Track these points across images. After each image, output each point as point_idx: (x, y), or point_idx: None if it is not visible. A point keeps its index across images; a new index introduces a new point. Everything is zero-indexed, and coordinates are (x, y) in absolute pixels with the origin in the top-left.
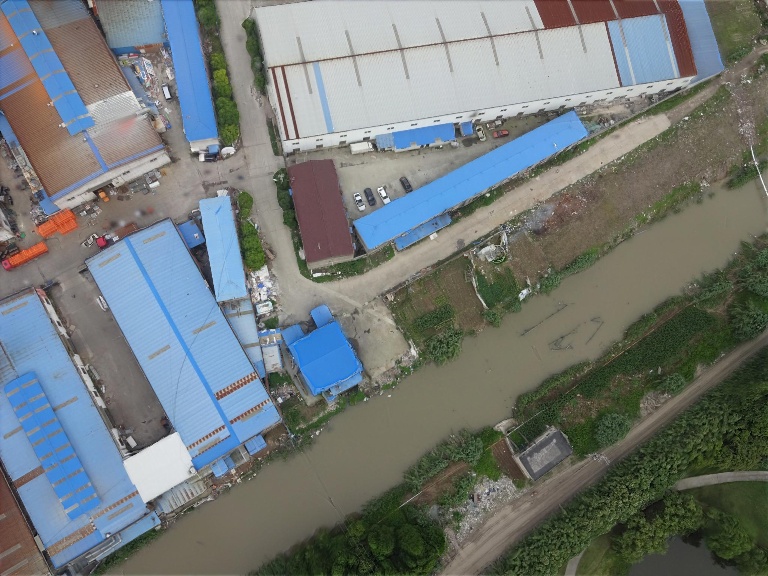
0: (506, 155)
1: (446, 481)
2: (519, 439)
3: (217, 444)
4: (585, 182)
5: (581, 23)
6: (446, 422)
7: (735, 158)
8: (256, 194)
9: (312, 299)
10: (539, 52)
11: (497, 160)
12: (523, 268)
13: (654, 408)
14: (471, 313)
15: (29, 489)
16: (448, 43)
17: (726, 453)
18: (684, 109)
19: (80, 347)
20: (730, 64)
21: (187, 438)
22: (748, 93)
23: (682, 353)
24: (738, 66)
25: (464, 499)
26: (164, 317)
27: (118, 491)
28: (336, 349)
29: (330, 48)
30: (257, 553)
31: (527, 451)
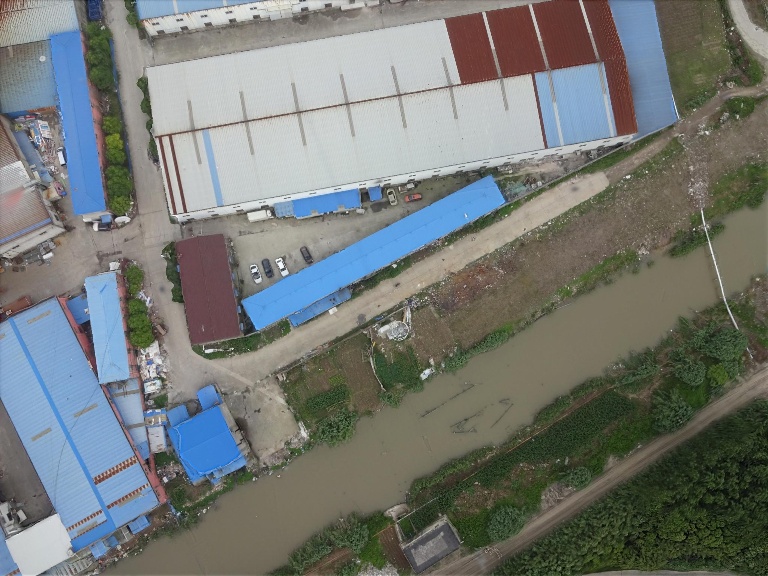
0: (410, 228)
1: (329, 567)
2: (408, 527)
3: (94, 528)
4: (504, 251)
5: (504, 76)
6: (335, 505)
7: (681, 223)
8: (150, 265)
9: (203, 376)
10: (453, 111)
11: (400, 233)
12: (426, 347)
13: (556, 501)
14: (368, 393)
15: None
16: (350, 104)
17: (628, 554)
18: (626, 166)
19: None
20: (687, 112)
21: (67, 520)
22: (704, 147)
23: (593, 443)
24: (696, 114)
25: None
26: (46, 400)
27: None
28: (216, 436)
29: (222, 113)
30: None
31: (412, 543)
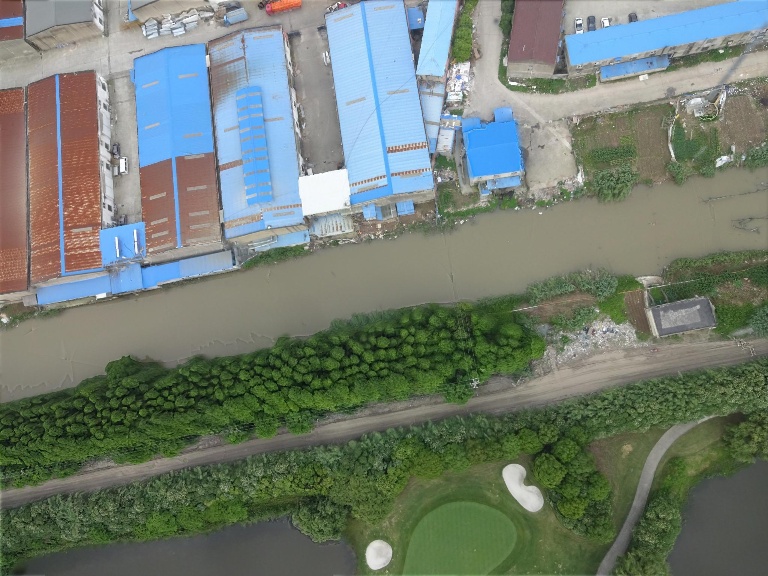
0: (758, 6)
1: (566, 305)
2: (659, 296)
3: (374, 189)
4: None
5: None
6: (588, 256)
7: None
8: None
9: (500, 103)
10: None
11: (745, 9)
12: (732, 133)
13: None
14: (655, 162)
15: (228, 174)
16: None
17: None
18: None
19: (298, 87)
20: None
21: (353, 177)
22: None
23: None
24: None
25: (578, 328)
26: (369, 73)
27: (288, 198)
28: (505, 143)
29: None
30: (374, 300)
31: (663, 305)
